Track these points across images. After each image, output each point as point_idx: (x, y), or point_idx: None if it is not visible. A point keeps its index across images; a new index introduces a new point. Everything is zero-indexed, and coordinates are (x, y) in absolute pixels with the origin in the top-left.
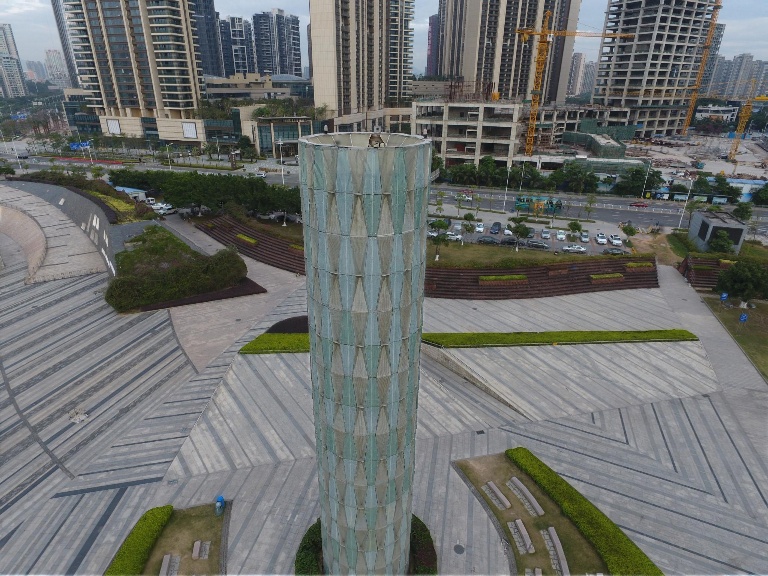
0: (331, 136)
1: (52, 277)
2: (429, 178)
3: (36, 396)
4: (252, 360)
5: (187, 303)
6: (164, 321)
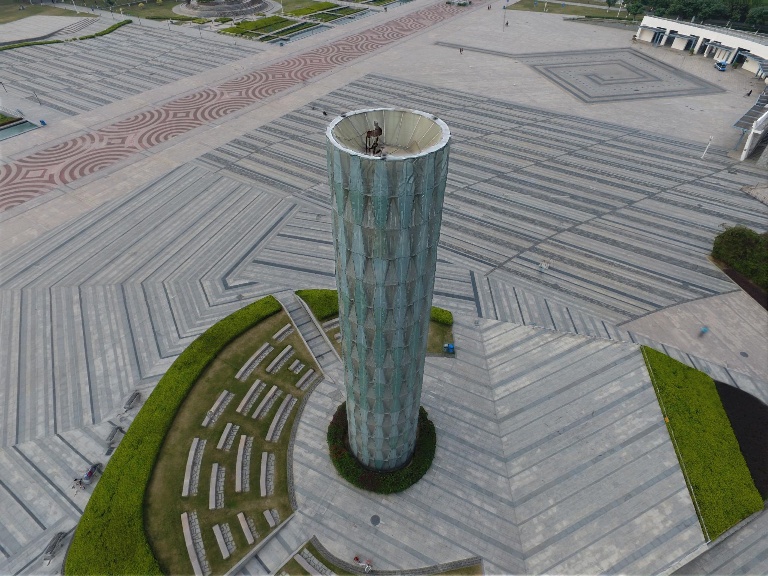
0: (434, 123)
1: (763, 198)
2: (361, 189)
3: (568, 240)
4: (633, 360)
5: (762, 302)
6: (711, 290)
